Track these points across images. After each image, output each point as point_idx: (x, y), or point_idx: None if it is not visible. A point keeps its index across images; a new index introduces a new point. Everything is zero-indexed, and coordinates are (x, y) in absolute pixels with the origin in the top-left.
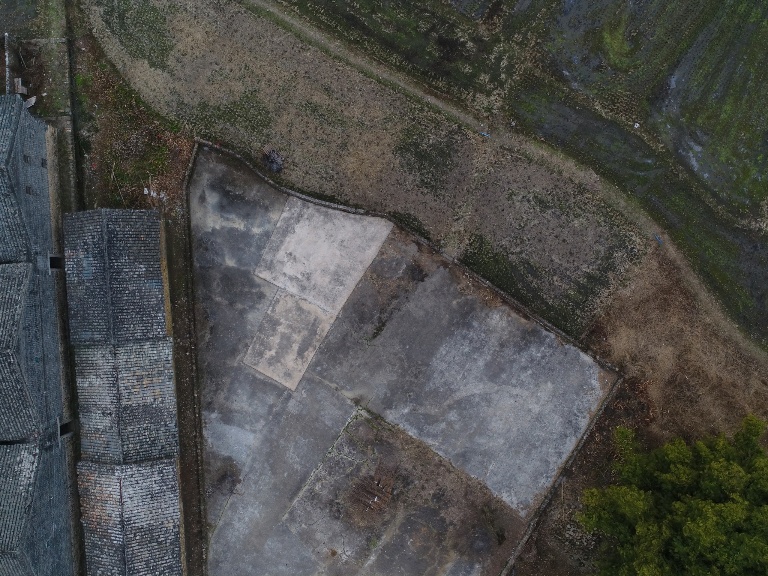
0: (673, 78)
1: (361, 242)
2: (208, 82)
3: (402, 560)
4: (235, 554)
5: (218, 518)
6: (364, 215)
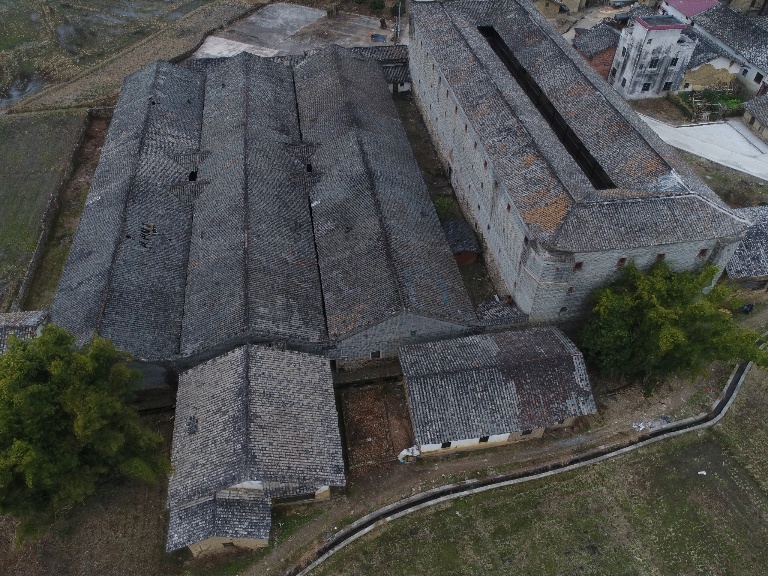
0: None
1: None
2: None
3: None
4: None
5: None
6: (204, 41)
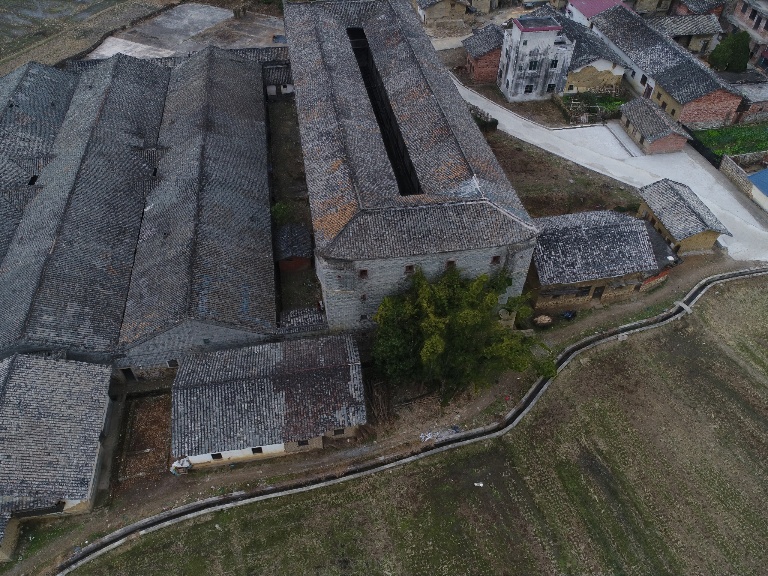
0: None
1: None
2: None
3: (254, 30)
4: None
5: None
6: (103, 42)
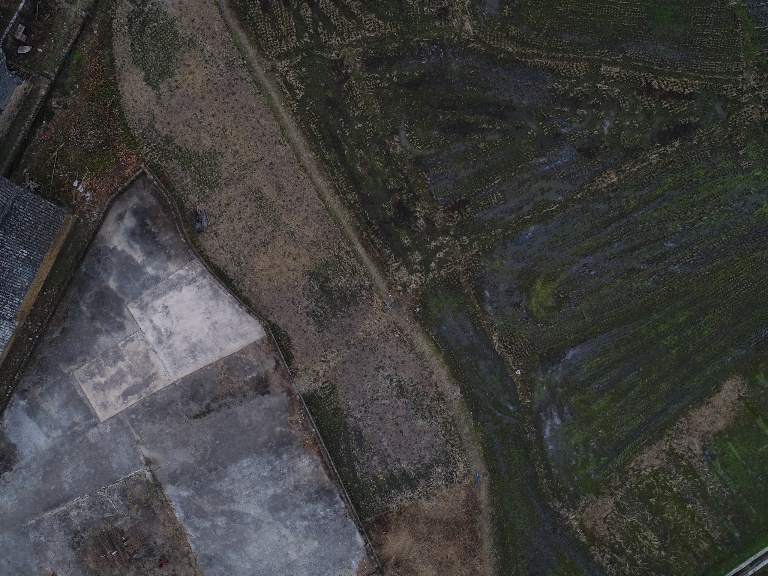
0: (572, 351)
1: (231, 333)
2: (185, 122)
3: None
4: None
5: None
6: None
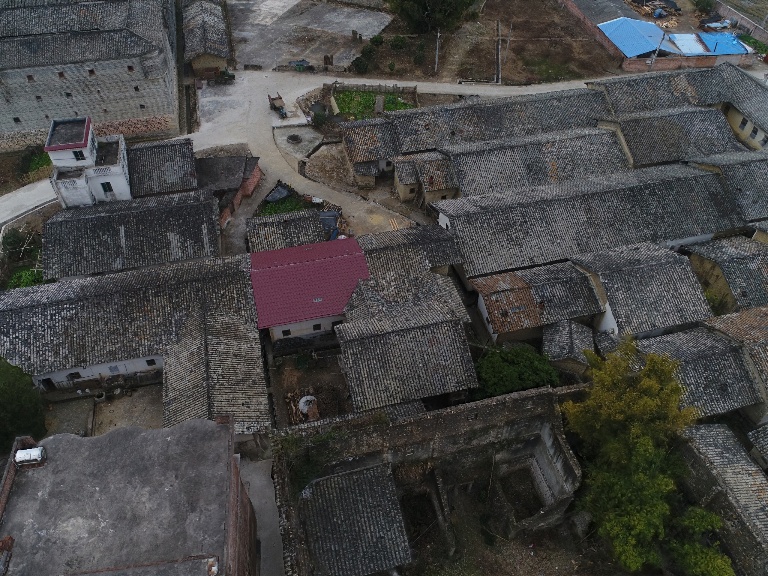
0: None
1: (292, 1)
2: None
3: None
4: (247, 54)
5: (239, 48)
6: None
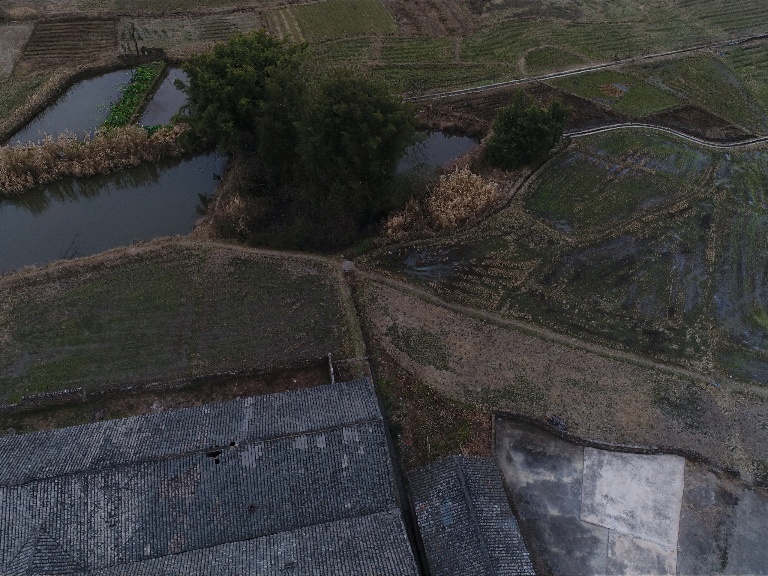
0: None
1: (664, 477)
2: (484, 374)
3: None
4: None
5: None
6: (655, 454)
